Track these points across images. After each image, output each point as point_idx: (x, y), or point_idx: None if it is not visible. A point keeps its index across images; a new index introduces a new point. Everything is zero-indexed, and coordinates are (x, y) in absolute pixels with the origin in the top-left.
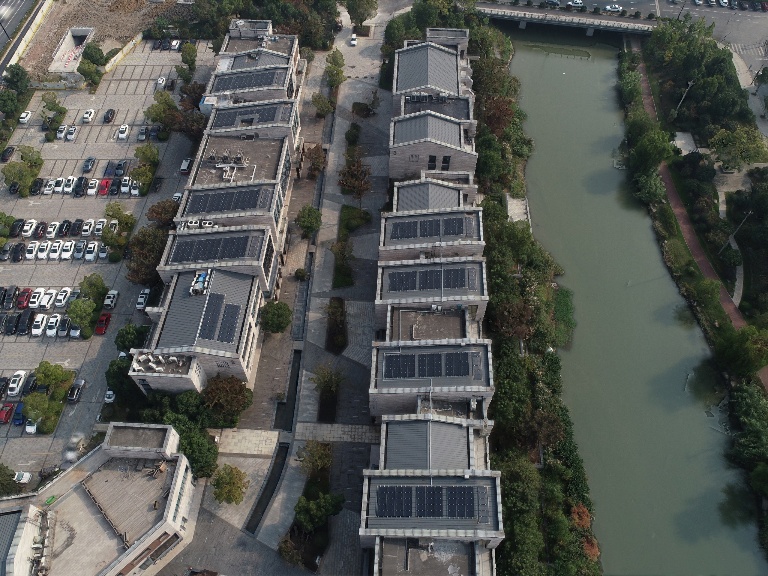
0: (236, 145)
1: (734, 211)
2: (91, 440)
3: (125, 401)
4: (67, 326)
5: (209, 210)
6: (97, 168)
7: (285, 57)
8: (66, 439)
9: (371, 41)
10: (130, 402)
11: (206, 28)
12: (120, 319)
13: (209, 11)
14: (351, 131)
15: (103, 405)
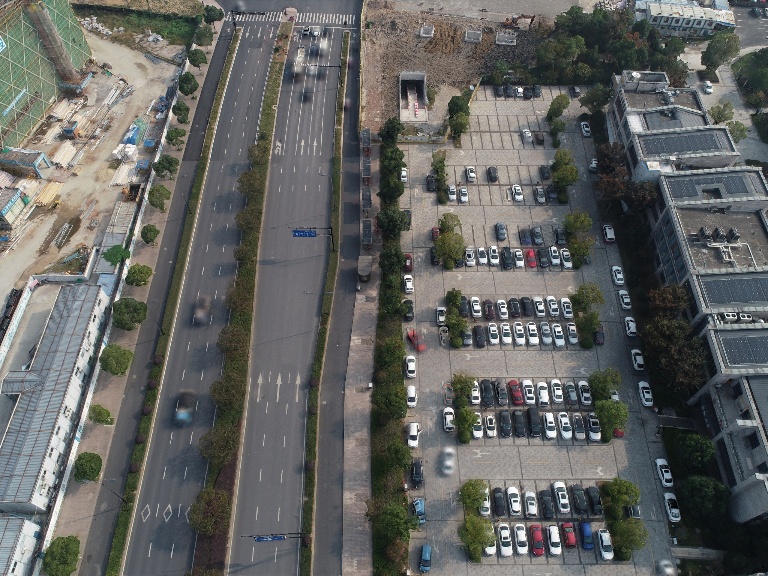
0: (710, 219)
1: None
2: (698, 573)
3: (693, 520)
4: (584, 427)
5: (738, 300)
6: (509, 235)
7: (699, 114)
8: (649, 567)
9: (724, 88)
10: (699, 522)
11: (550, 74)
12: (630, 418)
13: (554, 56)
14: None
15: (668, 524)
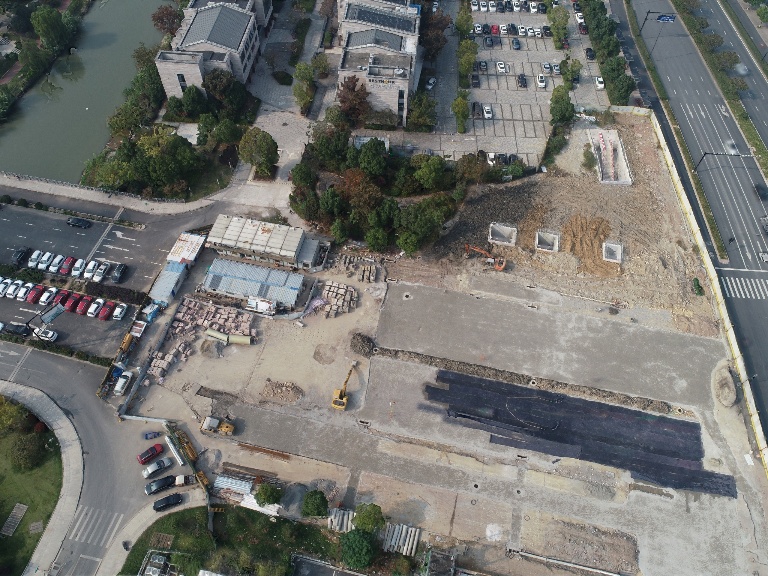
0: None
1: (25, 1)
2: None
3: None
4: None
5: None
6: (509, 44)
7: None
8: None
9: None
10: None
11: None
12: None
13: (456, 166)
14: (297, 41)
15: None
